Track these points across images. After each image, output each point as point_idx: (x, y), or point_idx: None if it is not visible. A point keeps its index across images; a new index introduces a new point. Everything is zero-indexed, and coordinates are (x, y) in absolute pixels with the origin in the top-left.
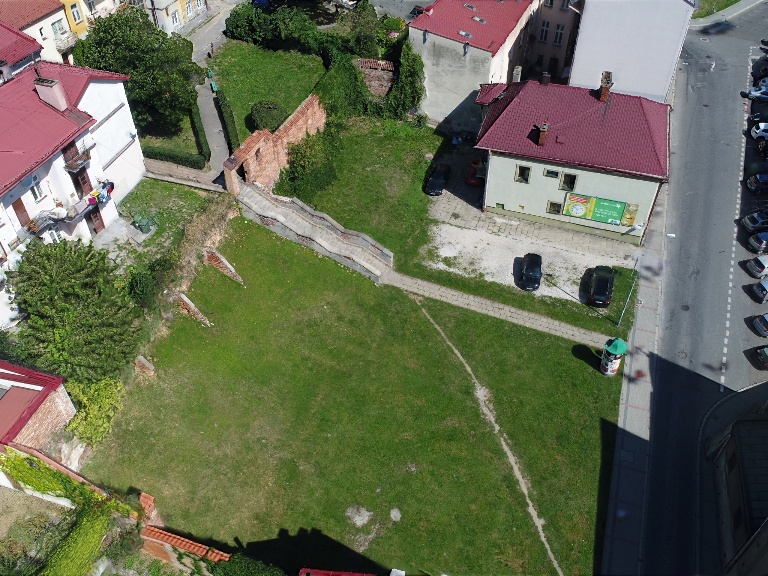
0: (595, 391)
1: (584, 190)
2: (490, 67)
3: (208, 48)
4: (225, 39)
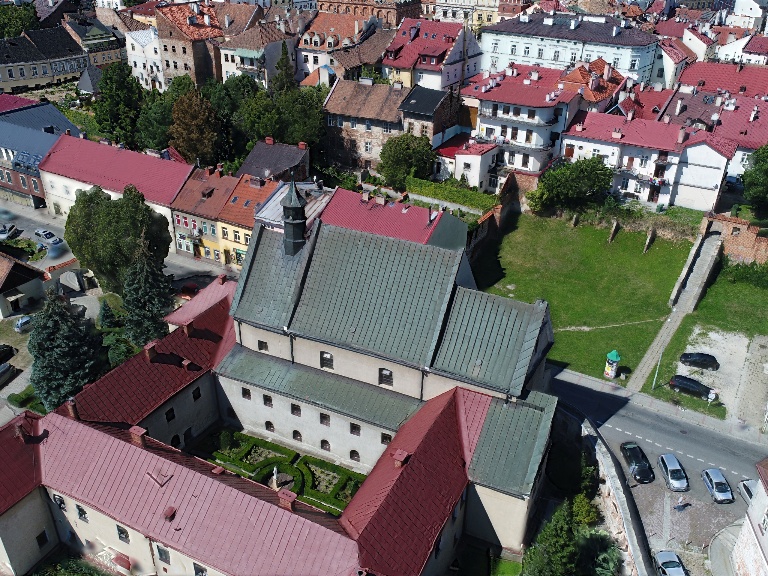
0: (591, 367)
1: None
2: None
3: None
4: None
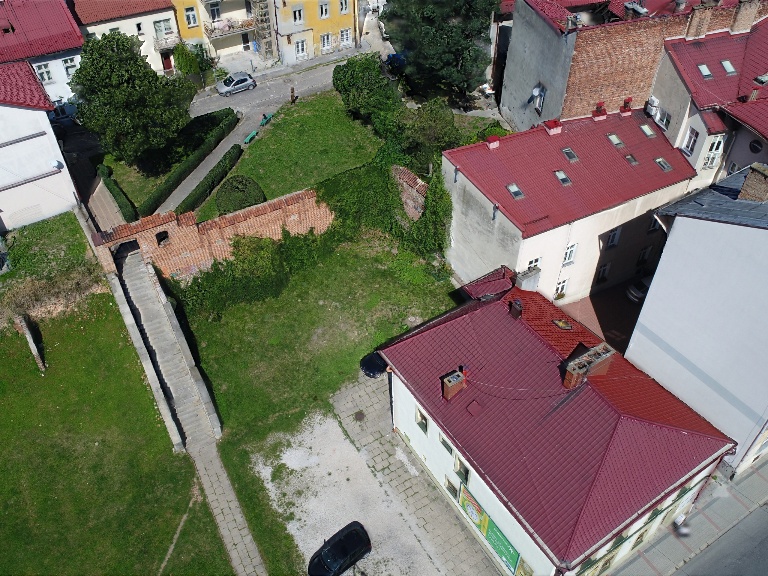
0: None
1: (477, 495)
2: (519, 249)
3: (303, 91)
4: (330, 87)
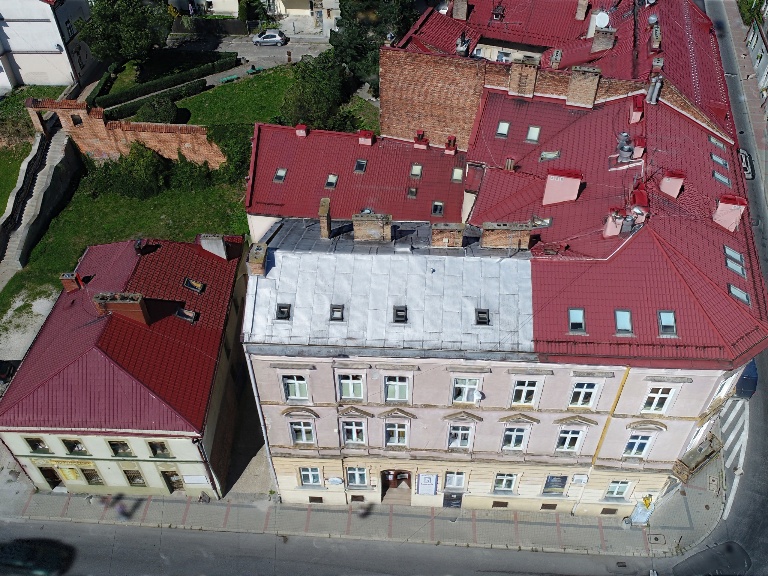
0: None
1: None
2: (249, 223)
3: None
4: None
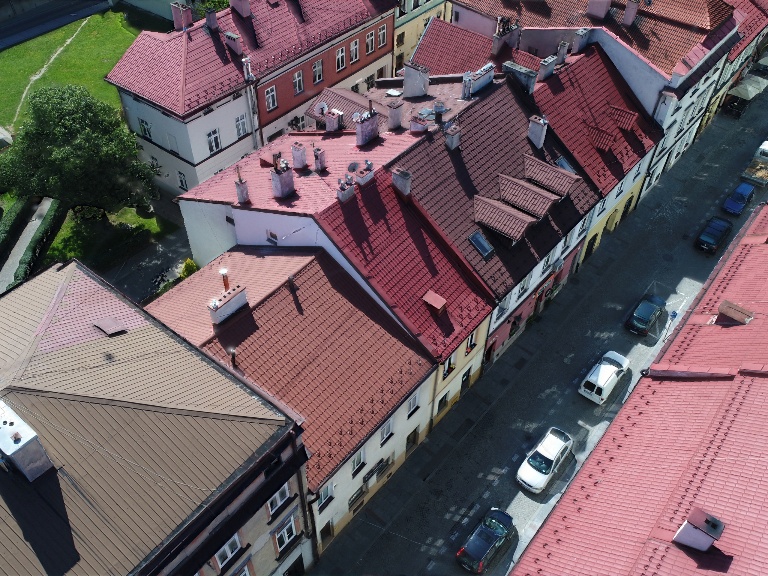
0: None
1: None
2: None
3: None
4: None
